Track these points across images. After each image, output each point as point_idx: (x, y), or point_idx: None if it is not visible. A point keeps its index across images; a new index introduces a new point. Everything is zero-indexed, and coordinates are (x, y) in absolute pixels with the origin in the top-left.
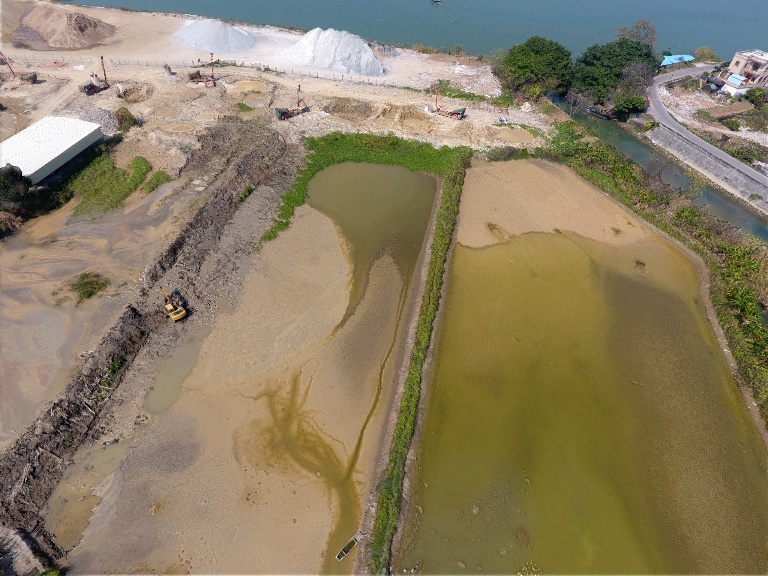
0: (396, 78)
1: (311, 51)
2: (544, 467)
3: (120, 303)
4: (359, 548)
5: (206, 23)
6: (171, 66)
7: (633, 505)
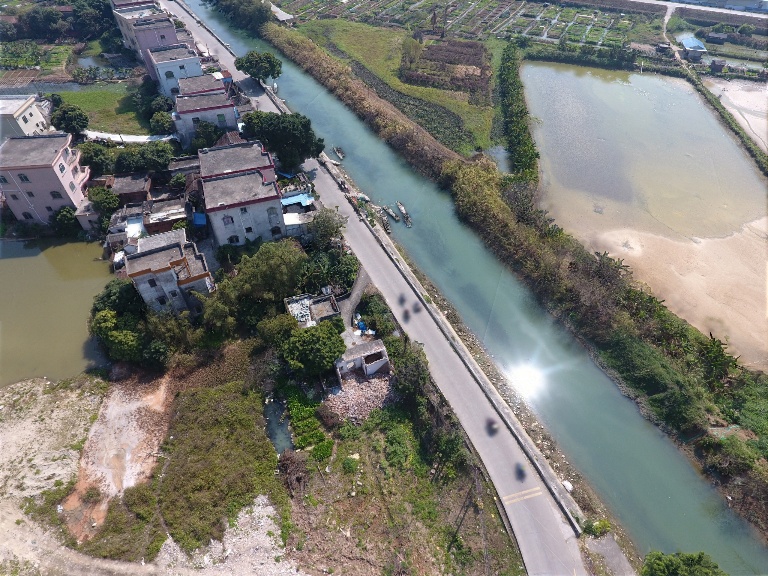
0: None
1: None
2: None
3: None
4: None
5: None
6: None
7: (603, 106)
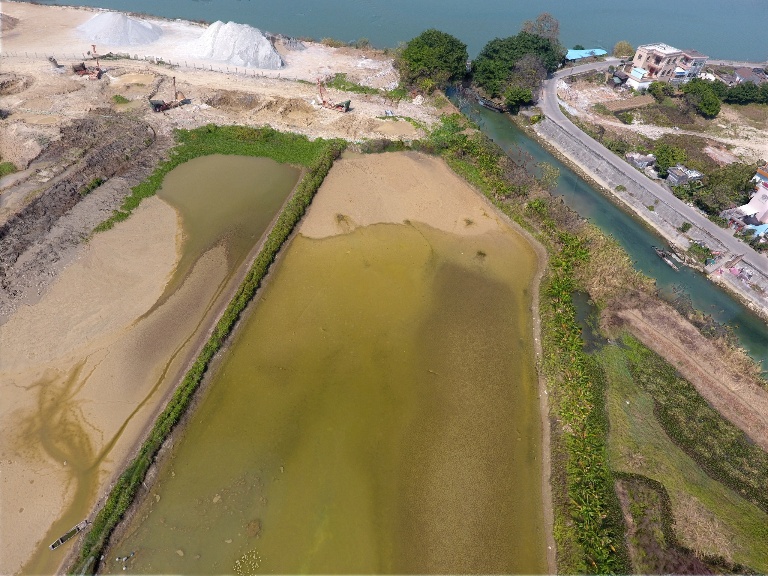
0: (294, 71)
1: (210, 44)
2: (305, 455)
3: None
4: (78, 537)
5: (107, 16)
6: (61, 59)
7: (383, 493)
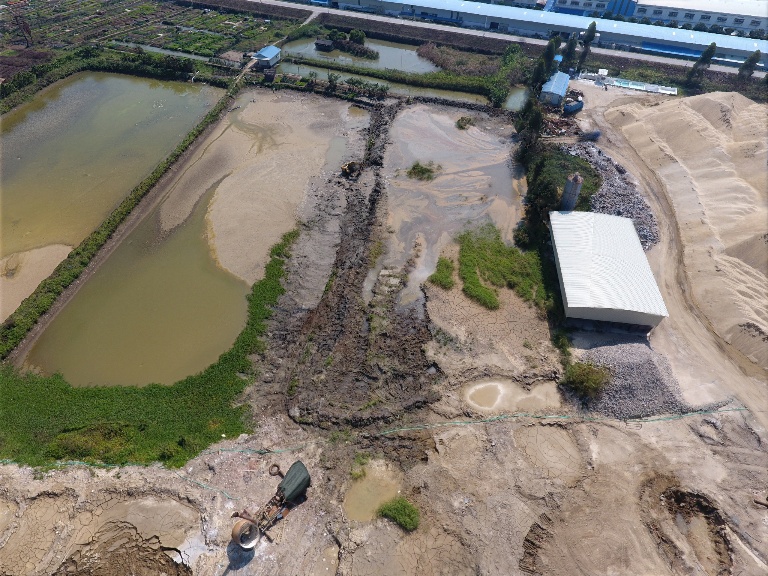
0: None
1: None
2: None
3: (390, 167)
4: None
5: None
6: None
7: (87, 120)
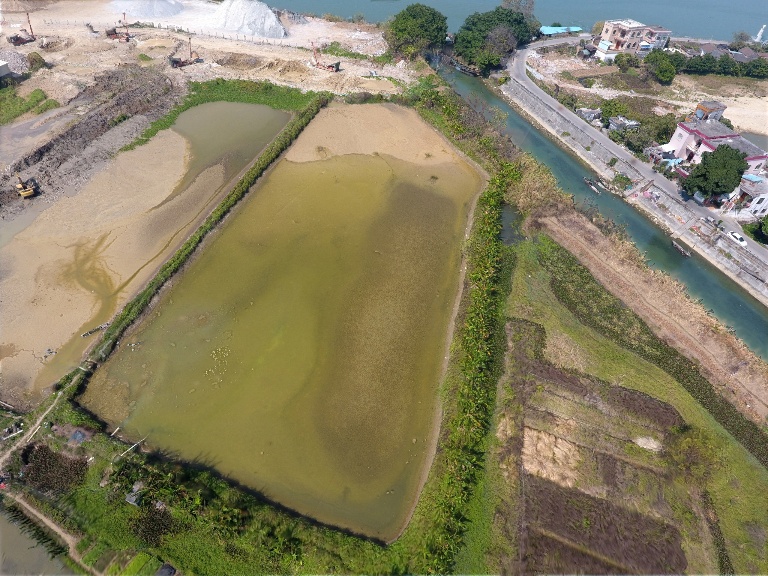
0: (295, 40)
1: (223, 16)
2: (270, 297)
3: None
4: (101, 332)
5: None
6: (96, 26)
7: (326, 321)
